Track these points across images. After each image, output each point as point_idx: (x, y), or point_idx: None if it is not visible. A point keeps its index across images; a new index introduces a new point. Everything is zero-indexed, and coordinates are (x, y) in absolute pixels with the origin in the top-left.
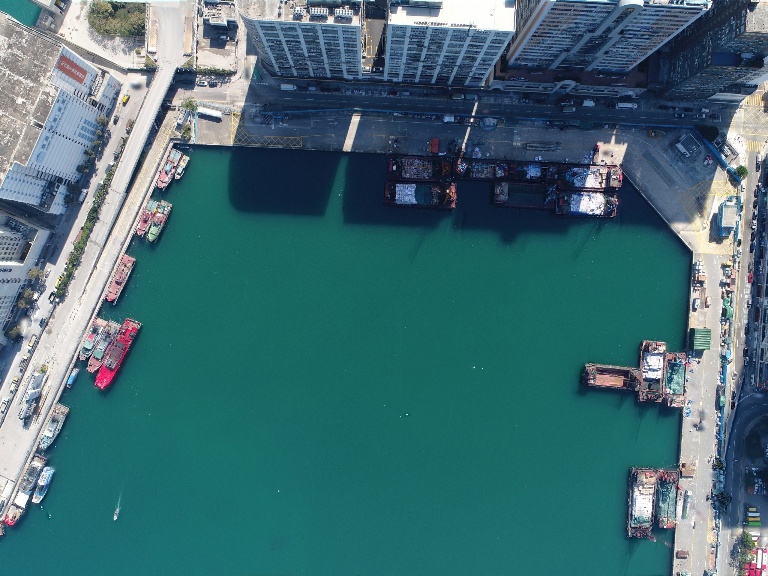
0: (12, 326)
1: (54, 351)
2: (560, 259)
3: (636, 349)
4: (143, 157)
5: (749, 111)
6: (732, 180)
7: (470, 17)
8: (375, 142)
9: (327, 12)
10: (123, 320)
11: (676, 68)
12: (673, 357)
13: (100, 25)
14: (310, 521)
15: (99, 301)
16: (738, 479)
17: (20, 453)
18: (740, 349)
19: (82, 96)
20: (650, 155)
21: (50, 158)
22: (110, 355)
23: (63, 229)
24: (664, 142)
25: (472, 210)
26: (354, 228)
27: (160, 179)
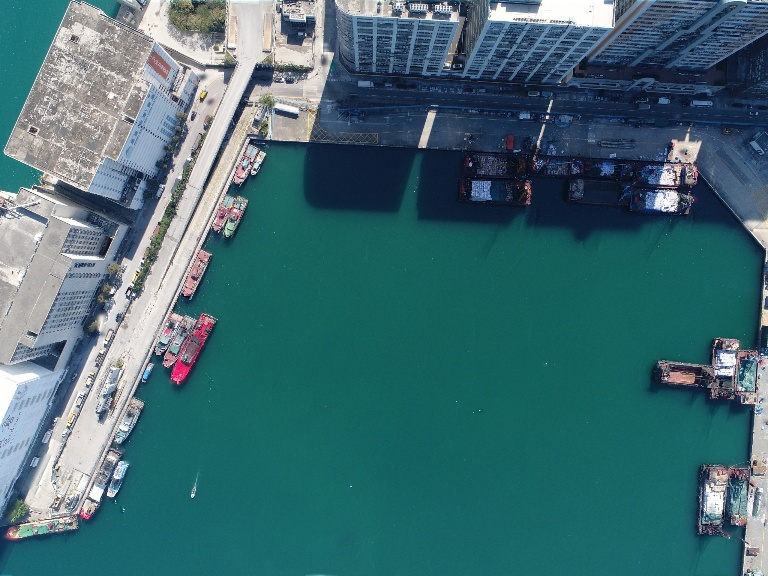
0: (90, 321)
1: (130, 346)
2: (633, 256)
3: (708, 346)
4: (220, 153)
5: None
6: None
7: (569, 14)
8: (450, 139)
9: (427, 8)
10: (198, 315)
11: (756, 66)
12: (746, 354)
13: (181, 21)
14: (382, 516)
15: (175, 296)
16: None
17: (95, 447)
18: None
19: (165, 92)
20: (724, 153)
21: (136, 153)
22: (186, 350)
23: (140, 224)
24: (738, 140)
25: (546, 207)
26: (428, 224)
27: (237, 175)
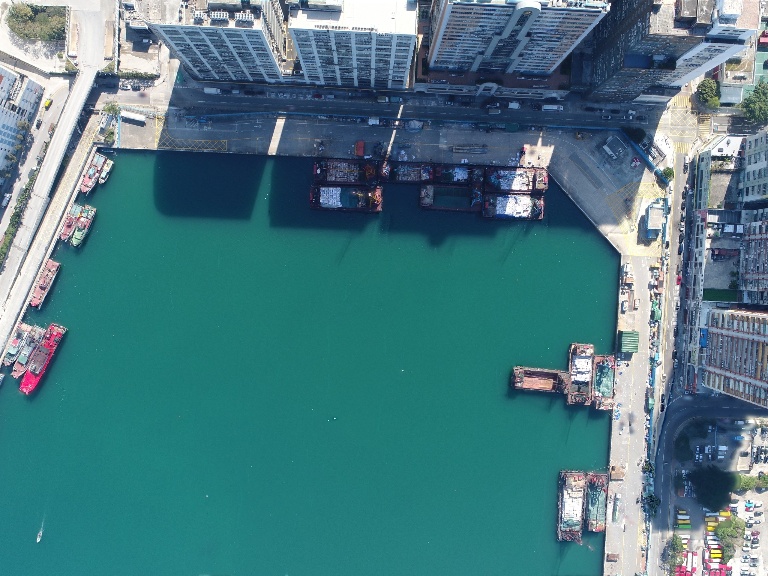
0: None
1: None
2: (488, 262)
3: (565, 352)
4: (66, 161)
5: (676, 113)
6: (660, 182)
7: (371, 20)
8: (300, 145)
9: (227, 16)
10: (48, 325)
11: (597, 70)
12: (601, 360)
13: (19, 29)
14: (238, 526)
15: (24, 306)
16: (668, 482)
17: None
18: (669, 351)
19: None
20: (577, 157)
21: None
22: (34, 360)
23: None
24: (591, 144)
25: (399, 213)
26: (281, 232)
27: (83, 183)
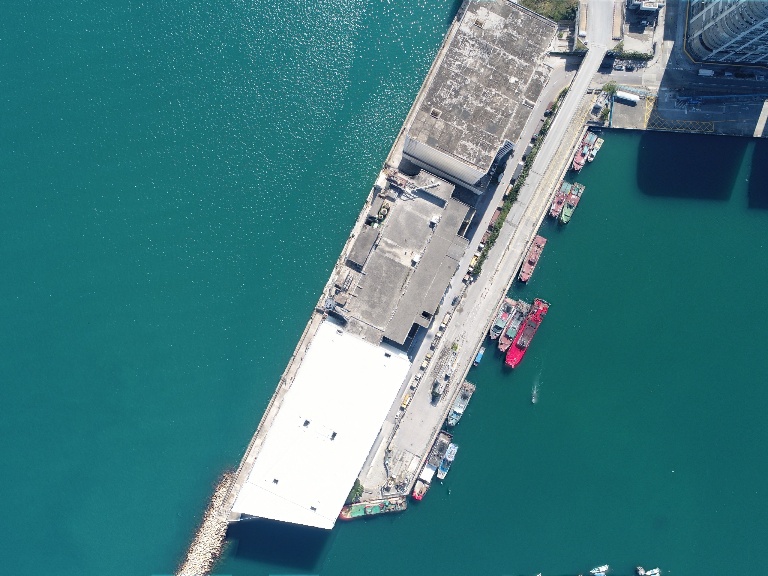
0: None
1: (464, 329)
2: None
3: None
4: None
5: None
6: None
7: None
8: None
9: None
10: (529, 300)
11: None
12: None
13: (537, 8)
14: (704, 502)
15: (510, 281)
16: None
17: (426, 429)
18: None
19: None
20: None
21: None
22: (523, 334)
23: (478, 209)
24: None
25: None
26: (755, 213)
27: (576, 161)
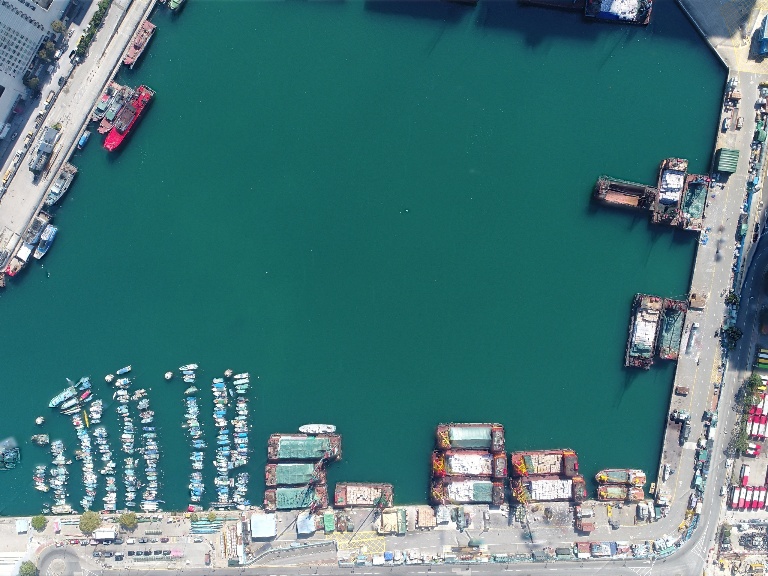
0: (32, 77)
1: (69, 111)
2: (584, 65)
3: (655, 168)
4: None
5: None
6: None
7: None
8: None
9: None
10: None
11: None
12: (694, 177)
13: None
14: (298, 310)
15: (117, 65)
16: (752, 318)
17: (27, 208)
18: None
19: None
20: None
21: None
22: (121, 117)
23: None
24: None
25: (497, 6)
26: (374, 17)
27: None
